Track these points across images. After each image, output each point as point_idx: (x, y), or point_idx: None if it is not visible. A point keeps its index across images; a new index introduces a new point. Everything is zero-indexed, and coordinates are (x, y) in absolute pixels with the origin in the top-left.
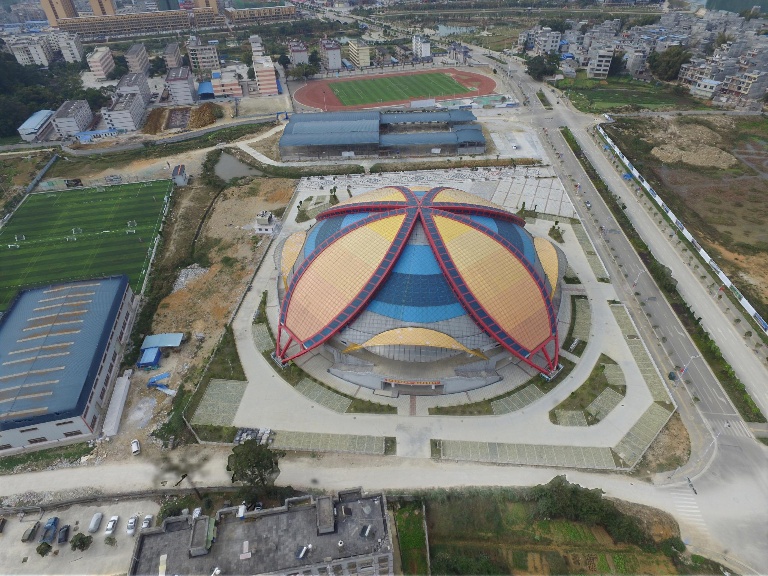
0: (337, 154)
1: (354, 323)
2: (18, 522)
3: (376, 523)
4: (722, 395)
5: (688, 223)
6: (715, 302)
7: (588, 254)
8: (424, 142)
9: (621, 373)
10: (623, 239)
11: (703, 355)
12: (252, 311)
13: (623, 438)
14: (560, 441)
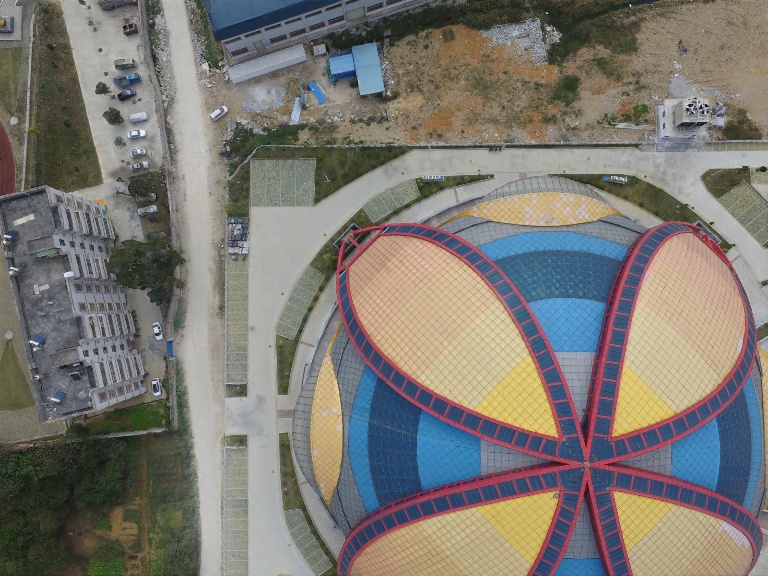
0: None
1: None
2: (136, 44)
3: (69, 405)
4: None
5: None
6: None
7: None
8: None
9: None
10: None
11: None
12: (444, 169)
13: None
14: None
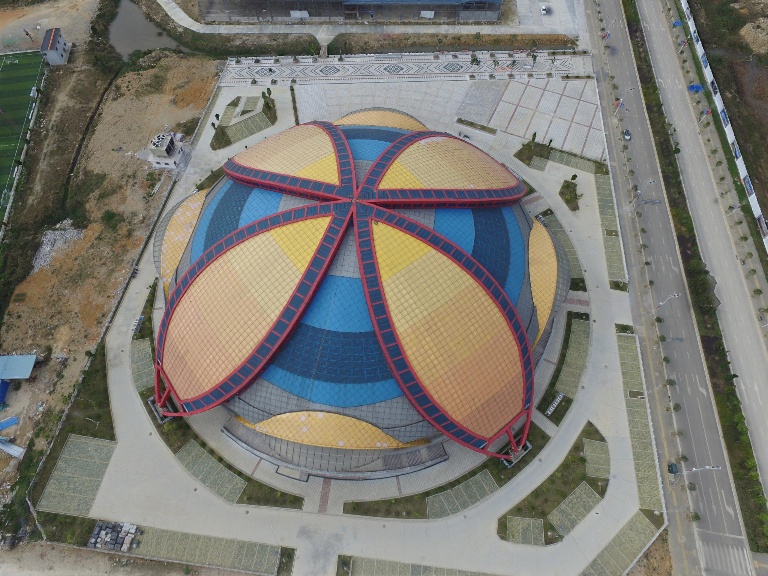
0: (284, 14)
1: (245, 393)
2: None
3: None
4: (732, 503)
5: (761, 180)
6: (762, 335)
7: (607, 235)
8: (410, 0)
9: (607, 457)
10: (662, 207)
11: (723, 432)
12: (134, 316)
13: (586, 569)
14: (504, 568)
